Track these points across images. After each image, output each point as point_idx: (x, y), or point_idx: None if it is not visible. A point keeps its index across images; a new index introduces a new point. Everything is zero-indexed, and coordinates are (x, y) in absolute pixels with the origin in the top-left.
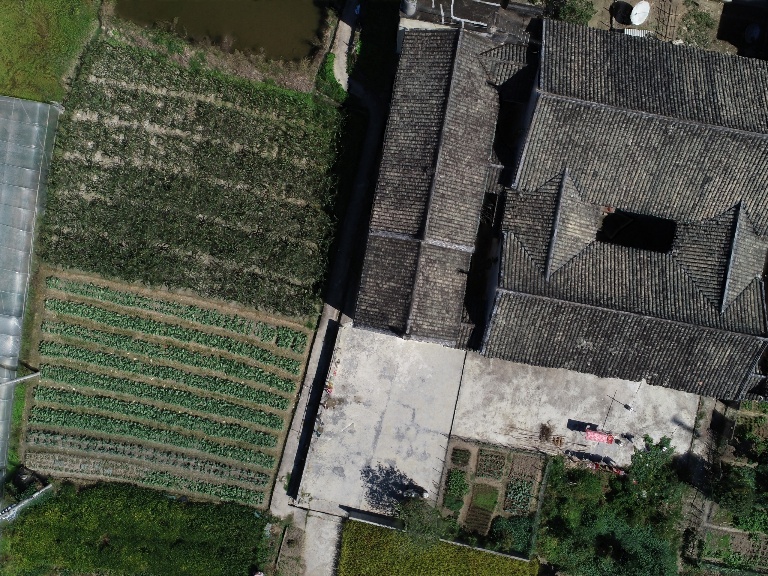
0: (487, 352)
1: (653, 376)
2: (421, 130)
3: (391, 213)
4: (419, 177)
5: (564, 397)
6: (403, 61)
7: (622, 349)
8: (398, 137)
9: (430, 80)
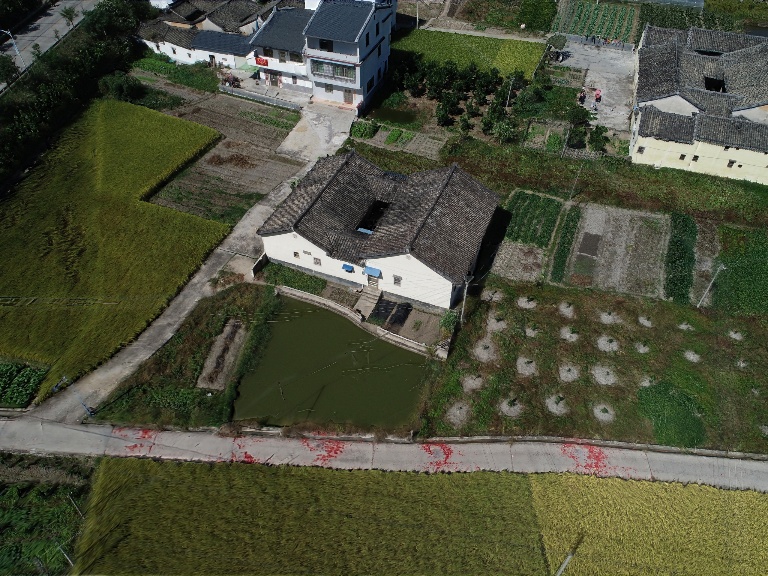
0: None
1: None
2: None
3: None
4: None
5: None
6: None
7: None
8: None
9: None
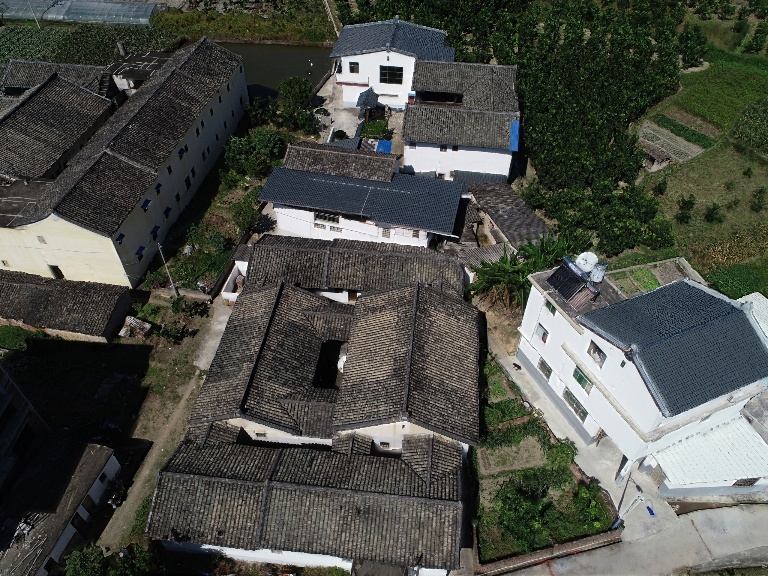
0: None
1: None
2: None
3: None
4: None
5: None
6: None
7: None
8: None
9: None
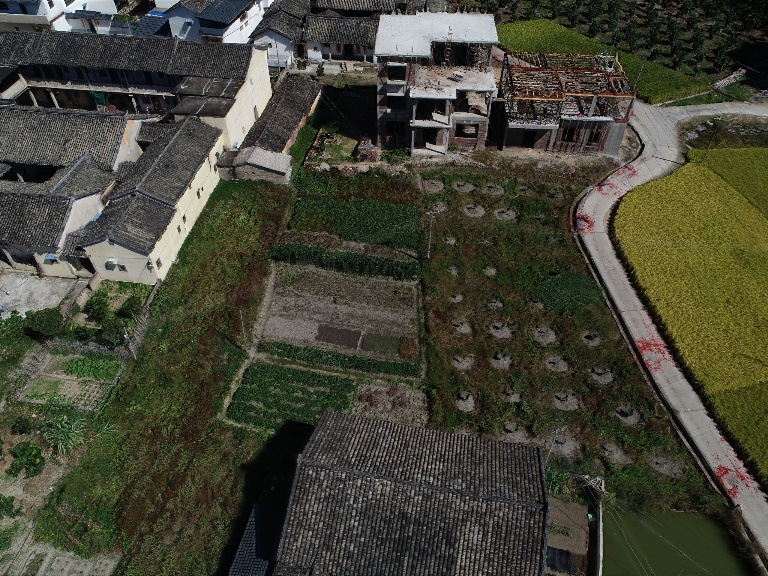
0: None
1: None
2: None
3: None
4: None
5: None
6: None
7: None
8: None
9: None
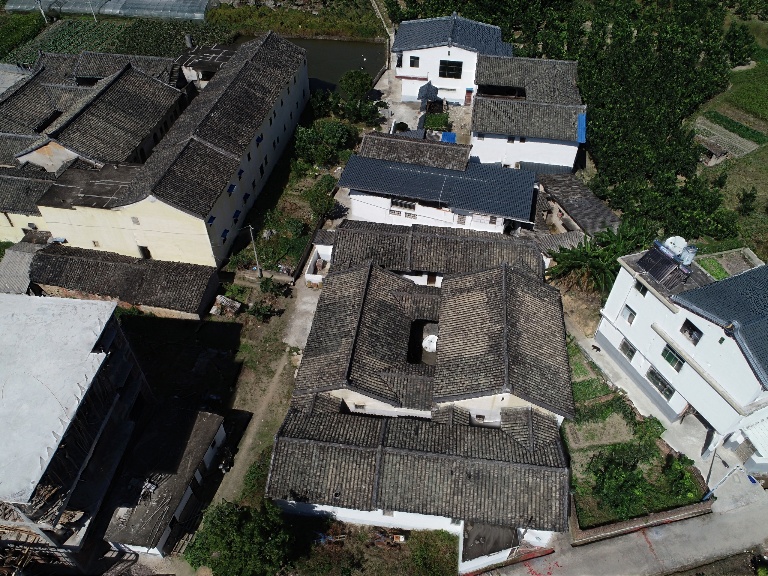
0: None
1: None
2: None
3: None
4: None
5: None
6: None
7: None
8: None
9: None
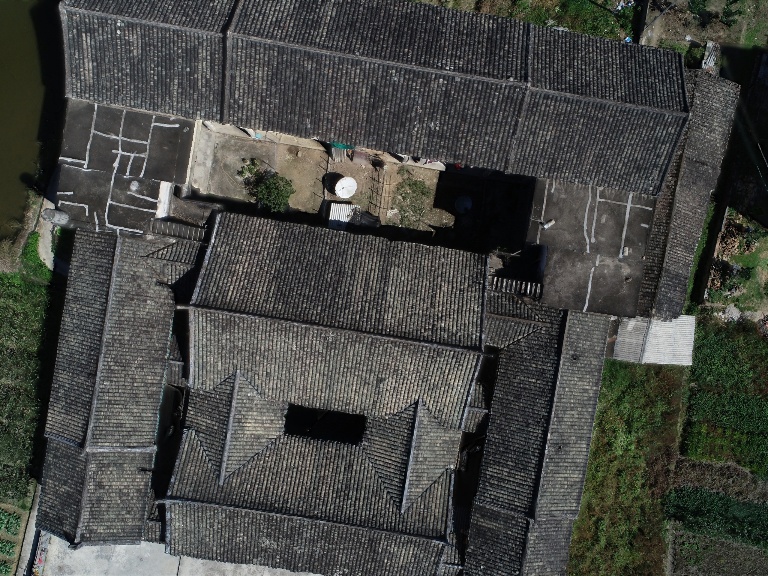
0: (172, 551)
1: (344, 571)
2: (87, 334)
3: (62, 417)
4: (85, 383)
5: (286, 573)
6: (74, 260)
7: (306, 548)
8: (69, 339)
9: (95, 284)
